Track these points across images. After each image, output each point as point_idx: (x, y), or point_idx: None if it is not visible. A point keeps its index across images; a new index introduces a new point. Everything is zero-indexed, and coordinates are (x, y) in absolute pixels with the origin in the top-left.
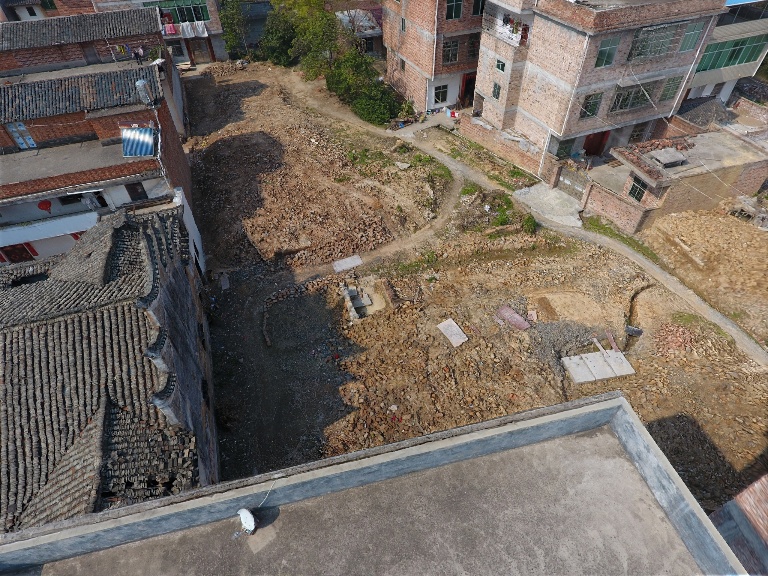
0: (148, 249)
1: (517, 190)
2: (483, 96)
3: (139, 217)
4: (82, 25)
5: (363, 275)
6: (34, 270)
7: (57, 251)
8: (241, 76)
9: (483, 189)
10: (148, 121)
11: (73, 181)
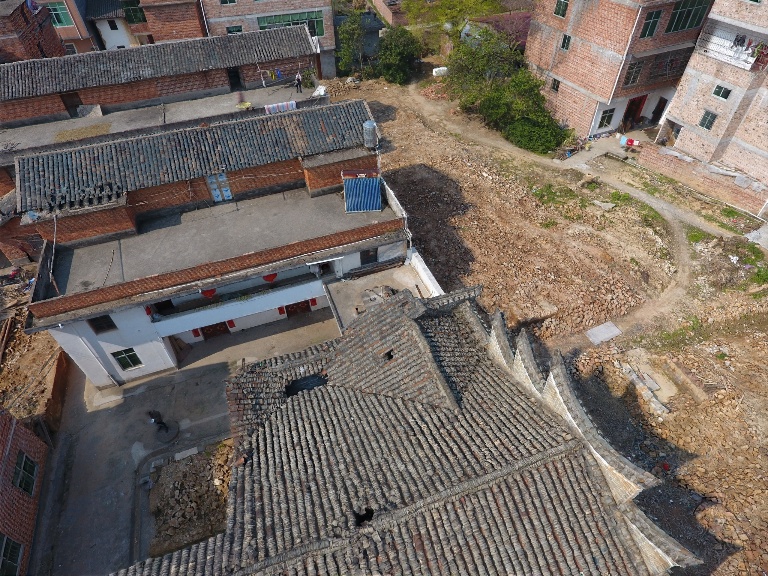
0: (568, 378)
1: (746, 234)
2: (681, 124)
3: (433, 302)
4: (228, 47)
5: (625, 347)
6: (306, 371)
7: (255, 321)
8: (357, 96)
9: (707, 233)
10: (377, 170)
11: (310, 248)
